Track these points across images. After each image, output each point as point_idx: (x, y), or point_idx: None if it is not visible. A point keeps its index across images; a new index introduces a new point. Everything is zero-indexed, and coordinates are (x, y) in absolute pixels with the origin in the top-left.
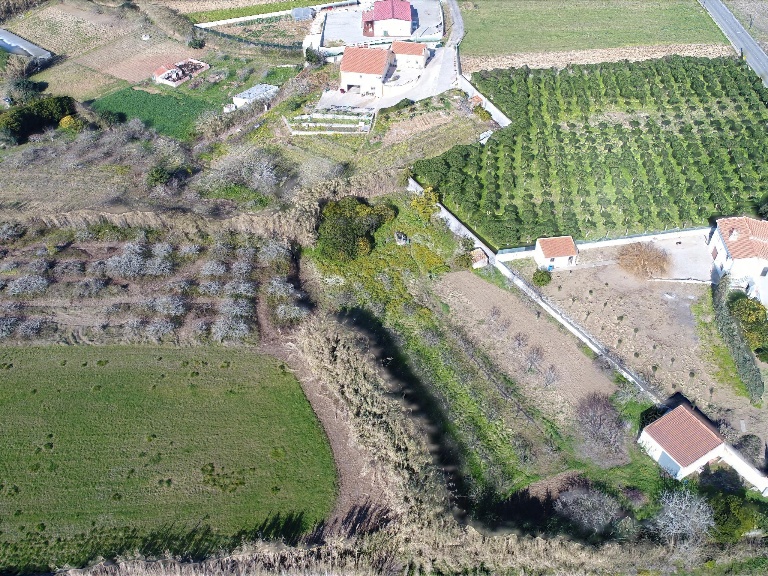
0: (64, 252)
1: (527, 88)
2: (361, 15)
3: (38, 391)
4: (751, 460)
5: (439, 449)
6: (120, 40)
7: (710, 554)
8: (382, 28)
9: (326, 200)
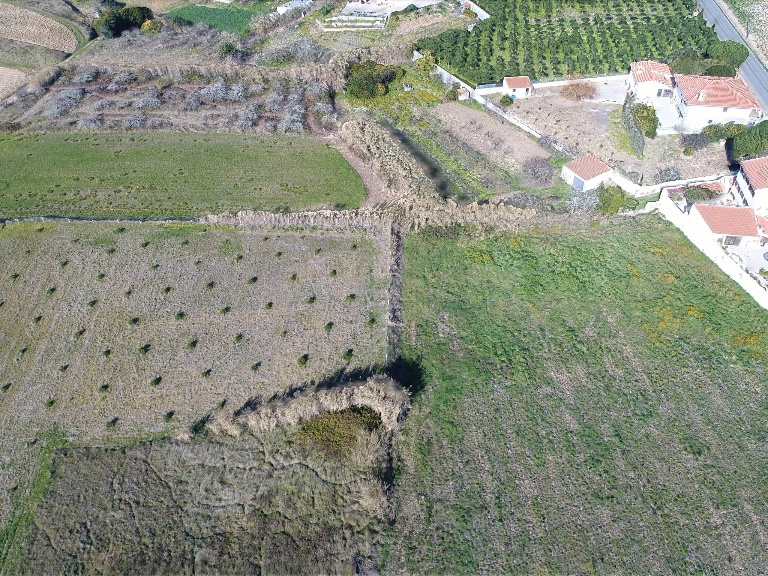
0: (168, 88)
1: None
2: None
3: (168, 151)
4: (630, 179)
5: (432, 177)
6: None
7: (596, 218)
8: None
9: (353, 62)
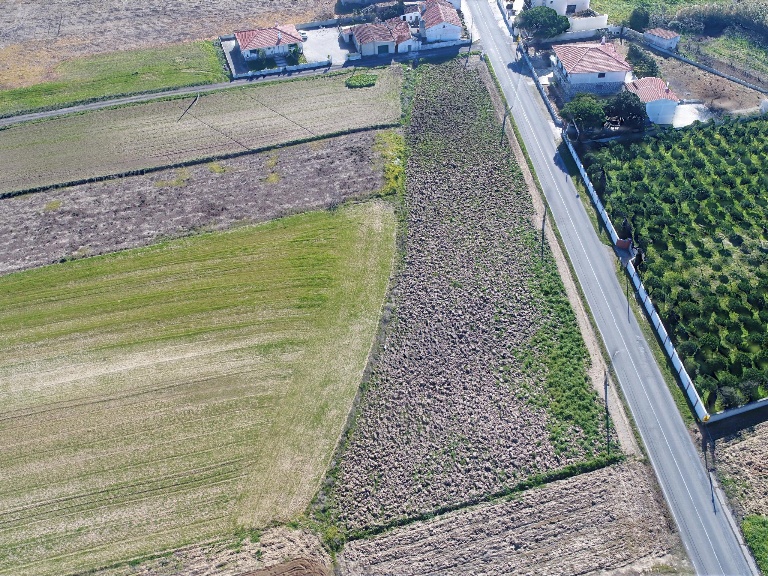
0: None
1: None
2: None
3: None
4: None
5: None
6: None
7: None
8: None
9: None
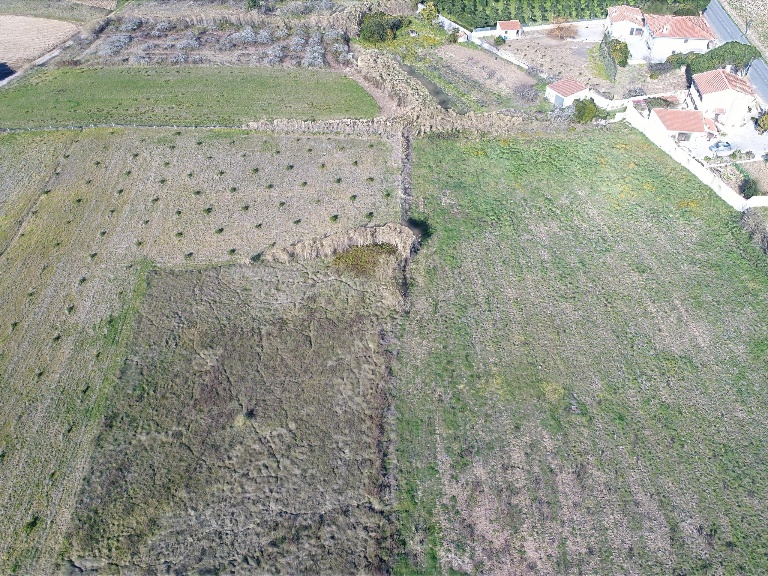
0: (204, 34)
1: None
2: None
3: (209, 80)
4: None
5: None
6: None
7: (573, 125)
8: None
9: (365, 13)
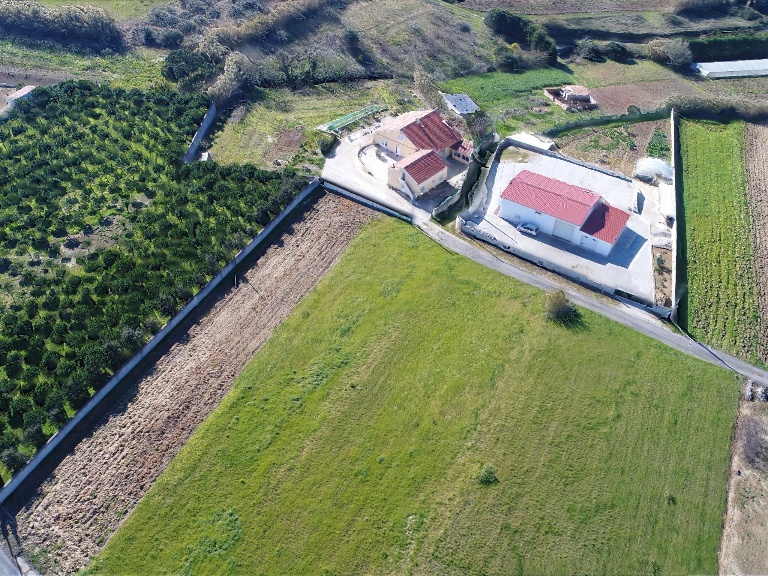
0: None
1: None
2: None
3: None
4: None
5: None
6: None
7: None
8: None
9: None
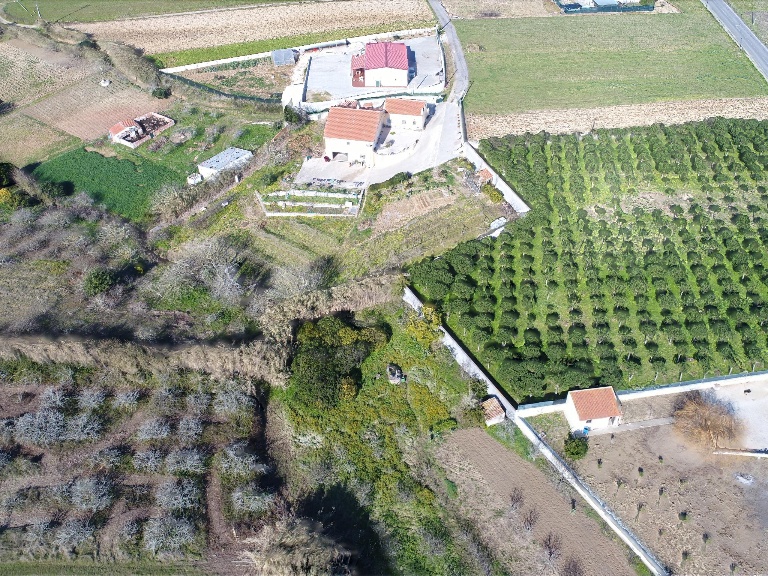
0: None
1: (545, 160)
2: (350, 60)
3: None
4: None
5: None
6: (76, 86)
7: None
8: (374, 78)
9: (302, 320)
